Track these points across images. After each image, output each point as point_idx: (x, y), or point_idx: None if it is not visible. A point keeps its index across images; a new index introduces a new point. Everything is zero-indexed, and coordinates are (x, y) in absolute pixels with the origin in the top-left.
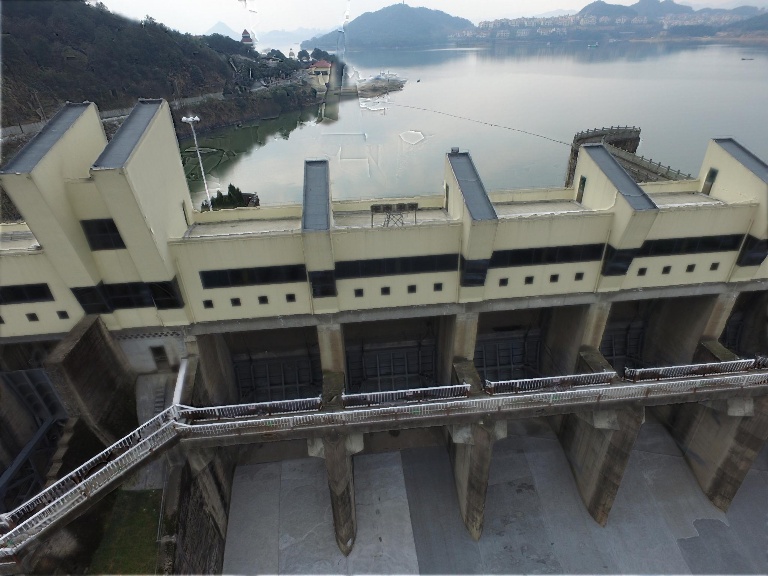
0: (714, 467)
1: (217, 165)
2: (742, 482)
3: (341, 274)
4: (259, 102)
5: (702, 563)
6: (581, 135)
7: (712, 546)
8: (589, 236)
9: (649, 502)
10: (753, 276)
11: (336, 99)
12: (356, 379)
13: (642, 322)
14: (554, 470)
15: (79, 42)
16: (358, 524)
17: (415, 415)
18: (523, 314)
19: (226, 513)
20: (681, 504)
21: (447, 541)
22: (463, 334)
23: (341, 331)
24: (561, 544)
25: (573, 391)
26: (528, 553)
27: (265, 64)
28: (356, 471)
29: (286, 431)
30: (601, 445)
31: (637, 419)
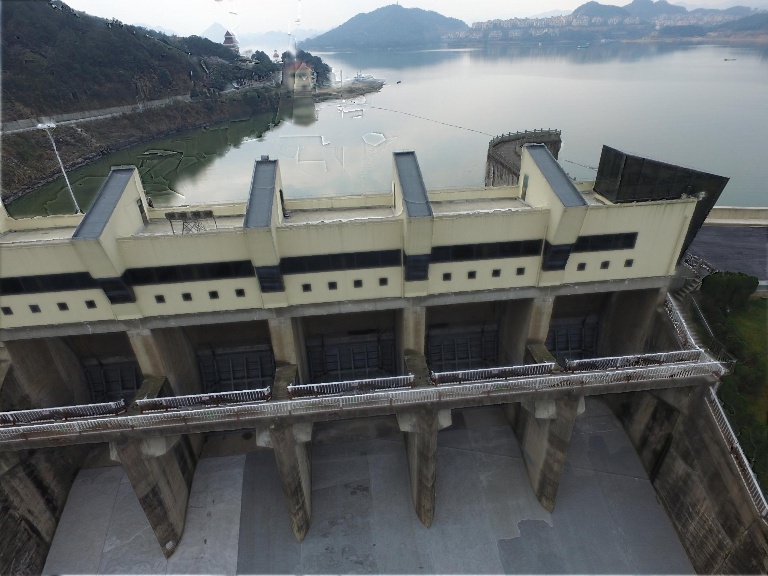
0: (538, 468)
1: (176, 168)
2: (575, 483)
3: (139, 281)
4: (228, 104)
5: (517, 563)
6: (502, 138)
7: (531, 546)
8: (384, 242)
9: (479, 503)
10: (562, 280)
11: (289, 102)
12: (209, 383)
13: (496, 325)
14: (392, 472)
15: (41, 45)
16: (186, 526)
17: (204, 419)
18: (381, 318)
19: (56, 516)
20: (510, 505)
21: (271, 543)
22: (280, 339)
23: (162, 336)
24: (382, 545)
25: (362, 395)
26: (348, 554)
27: (238, 66)
28: (196, 474)
29: (74, 436)
30: (414, 447)
31: (427, 422)
